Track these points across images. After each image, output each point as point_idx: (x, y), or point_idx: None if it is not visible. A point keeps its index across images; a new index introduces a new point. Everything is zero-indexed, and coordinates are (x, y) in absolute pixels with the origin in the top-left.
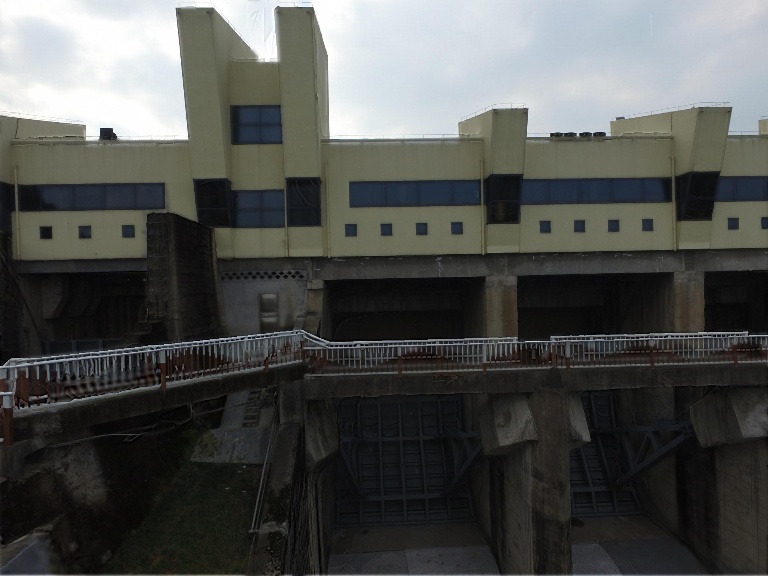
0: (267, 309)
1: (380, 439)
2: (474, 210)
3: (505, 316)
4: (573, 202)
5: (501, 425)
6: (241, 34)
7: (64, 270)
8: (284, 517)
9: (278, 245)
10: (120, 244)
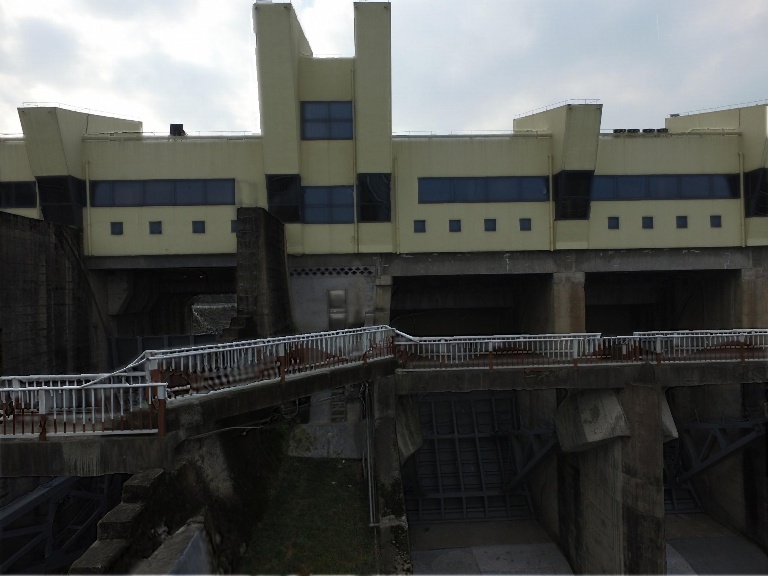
0: (335, 305)
1: (435, 436)
2: (542, 206)
3: (573, 313)
4: (641, 198)
5: (588, 421)
6: None
7: (134, 266)
8: (402, 511)
9: (347, 241)
10: (190, 240)
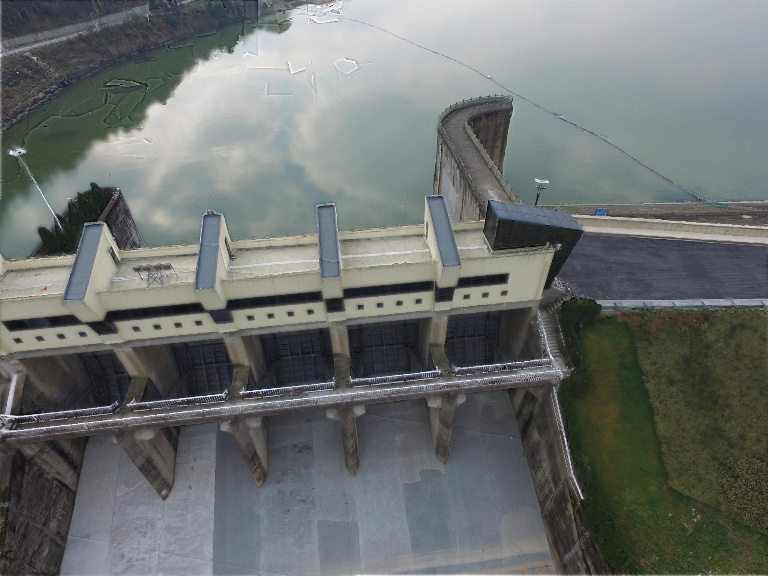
0: None
1: (114, 376)
2: None
3: (132, 362)
4: (149, 318)
5: None
6: None
7: None
8: (5, 501)
9: None
10: None
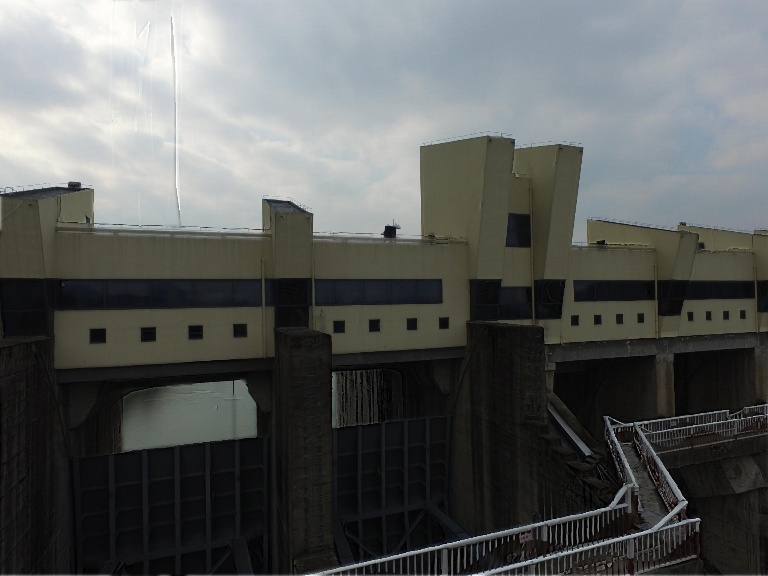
0: None
1: None
2: (650, 304)
3: (667, 385)
4: (705, 298)
5: (733, 477)
6: None
7: (352, 363)
8: None
9: None
10: (405, 336)
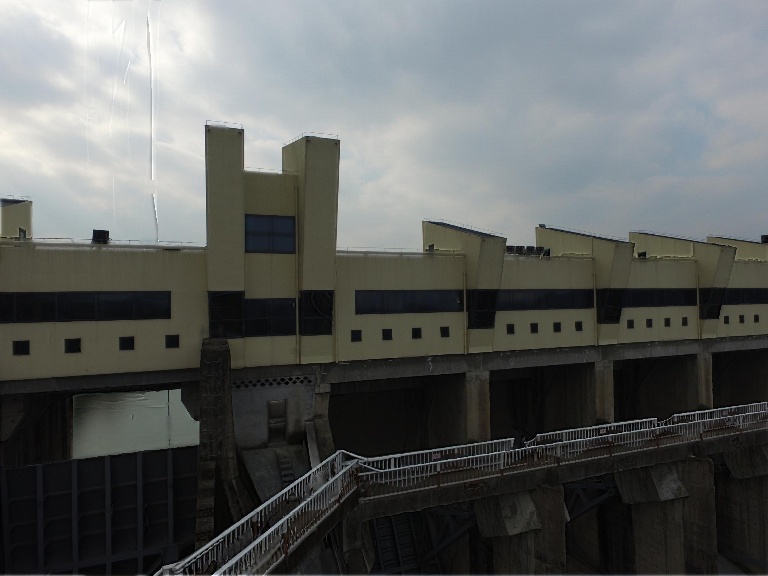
0: (275, 415)
1: None
2: (458, 316)
3: (481, 406)
4: (530, 308)
5: (508, 517)
6: (83, 19)
7: (42, 389)
8: None
9: (289, 352)
10: (116, 358)
